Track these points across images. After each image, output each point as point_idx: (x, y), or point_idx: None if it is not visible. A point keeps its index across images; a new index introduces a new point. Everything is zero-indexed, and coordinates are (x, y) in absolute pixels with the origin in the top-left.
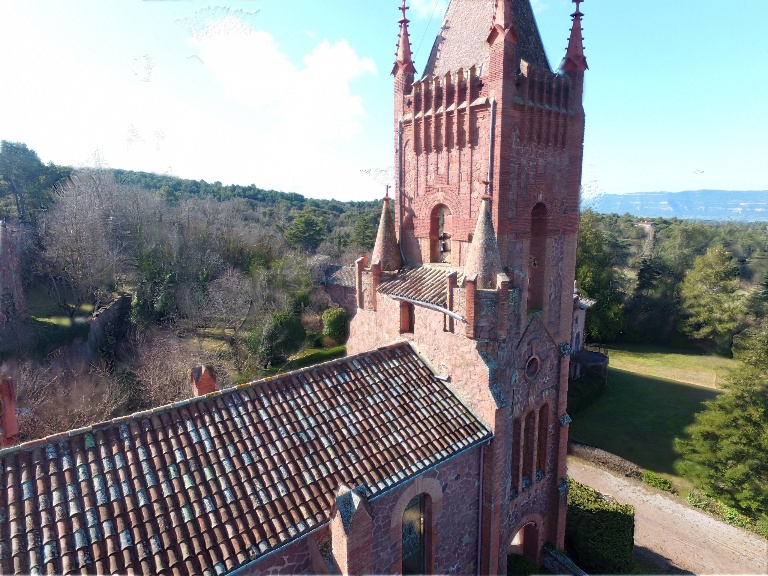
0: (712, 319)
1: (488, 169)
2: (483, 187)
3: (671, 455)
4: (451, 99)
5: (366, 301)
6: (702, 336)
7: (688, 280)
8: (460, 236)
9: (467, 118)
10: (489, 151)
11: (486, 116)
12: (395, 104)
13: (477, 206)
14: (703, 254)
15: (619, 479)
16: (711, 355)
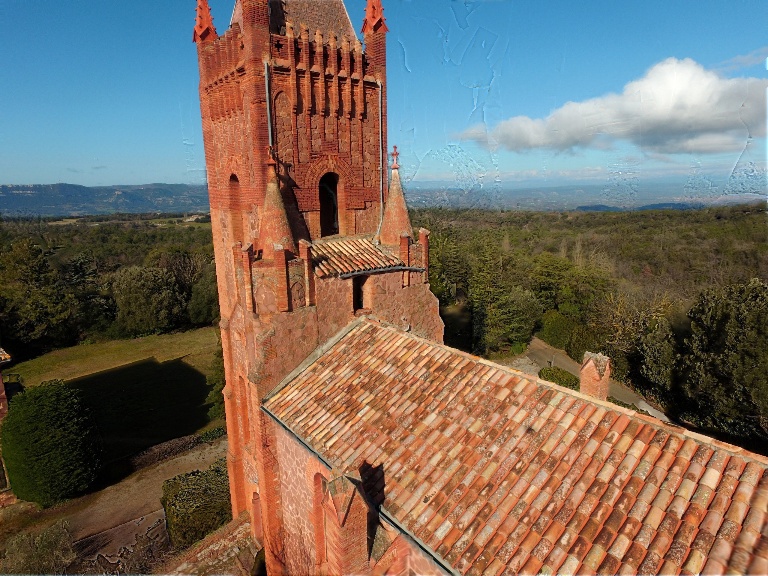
0: (43, 315)
1: (380, 142)
2: (374, 158)
3: (176, 420)
4: (339, 64)
5: (296, 299)
6: (40, 335)
7: (2, 282)
8: (357, 204)
9: (361, 91)
10: (380, 127)
11: (374, 94)
12: (255, 37)
13: (369, 175)
14: (8, 251)
15: (190, 454)
16: (52, 351)
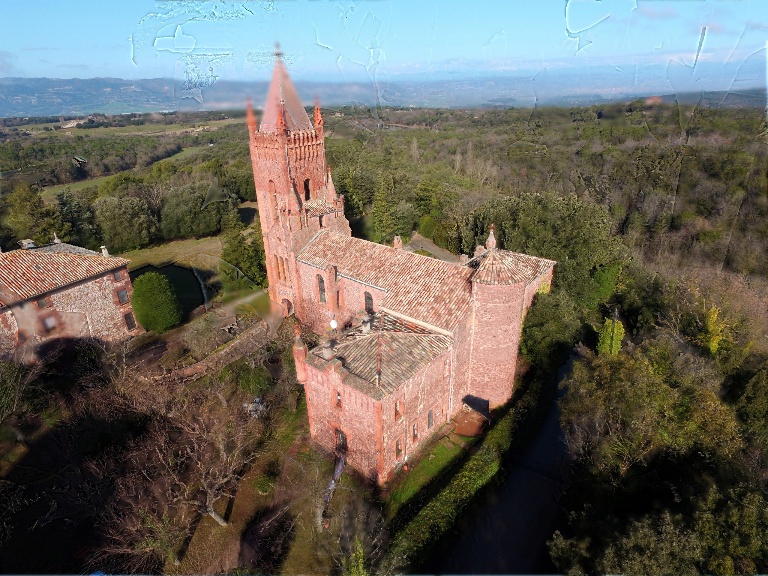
0: None
1: (323, 164)
2: (321, 170)
3: (199, 296)
4: None
5: None
6: None
7: (14, 216)
8: None
9: None
10: None
11: None
12: None
13: None
14: None
15: None
16: None
